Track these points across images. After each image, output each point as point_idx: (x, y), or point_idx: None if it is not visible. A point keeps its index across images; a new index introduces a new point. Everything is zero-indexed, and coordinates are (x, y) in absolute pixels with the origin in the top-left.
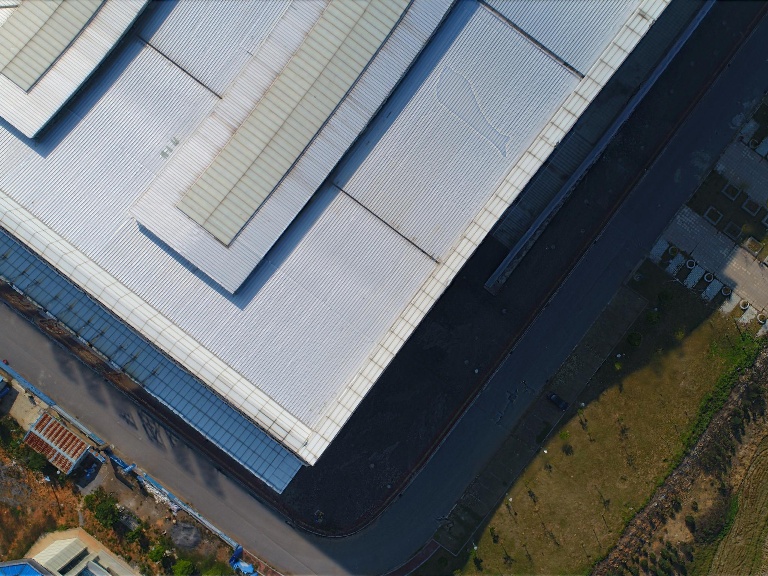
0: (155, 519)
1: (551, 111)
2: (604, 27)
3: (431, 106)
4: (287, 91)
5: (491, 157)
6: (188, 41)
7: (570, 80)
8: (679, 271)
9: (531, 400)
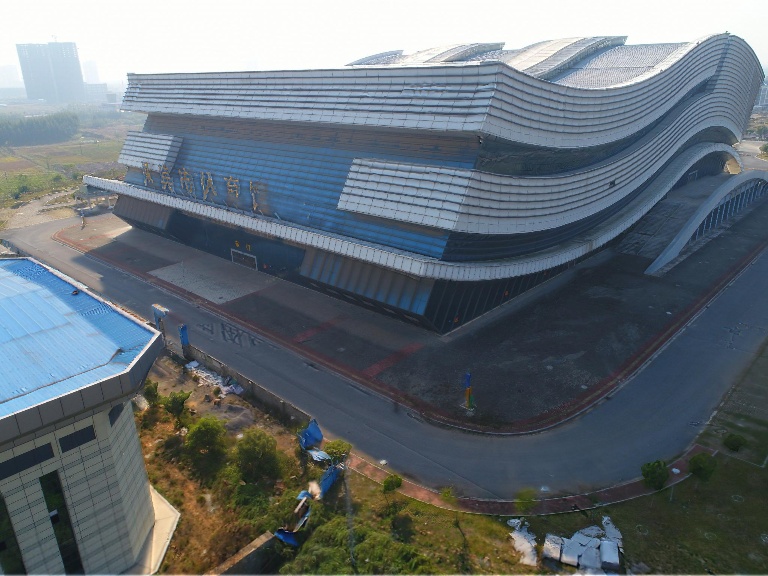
0: (186, 400)
1: None
2: None
3: None
4: None
5: None
6: None
7: None
8: None
9: (764, 334)
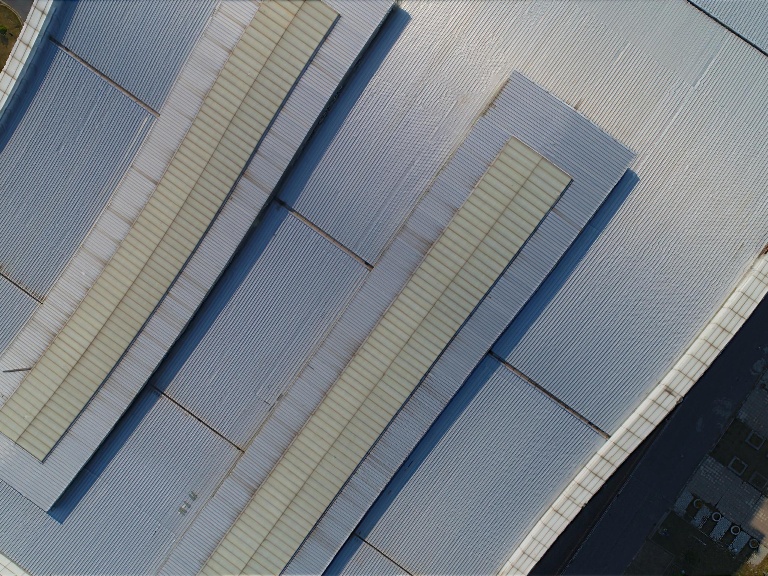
0: None
1: (577, 467)
2: (629, 393)
3: (453, 457)
4: (306, 451)
5: (516, 508)
6: (204, 391)
7: (596, 439)
8: (705, 524)
9: None
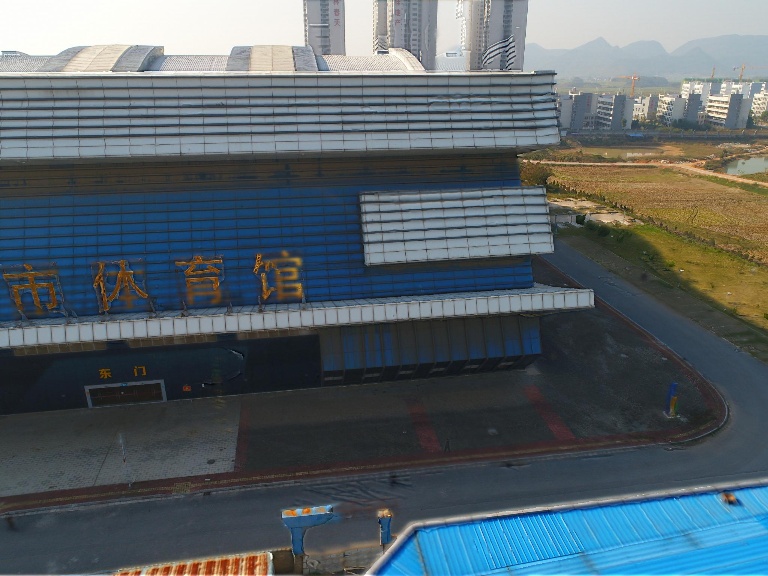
0: None
1: None
2: None
3: None
4: None
5: None
6: None
7: None
8: (567, 226)
9: None
